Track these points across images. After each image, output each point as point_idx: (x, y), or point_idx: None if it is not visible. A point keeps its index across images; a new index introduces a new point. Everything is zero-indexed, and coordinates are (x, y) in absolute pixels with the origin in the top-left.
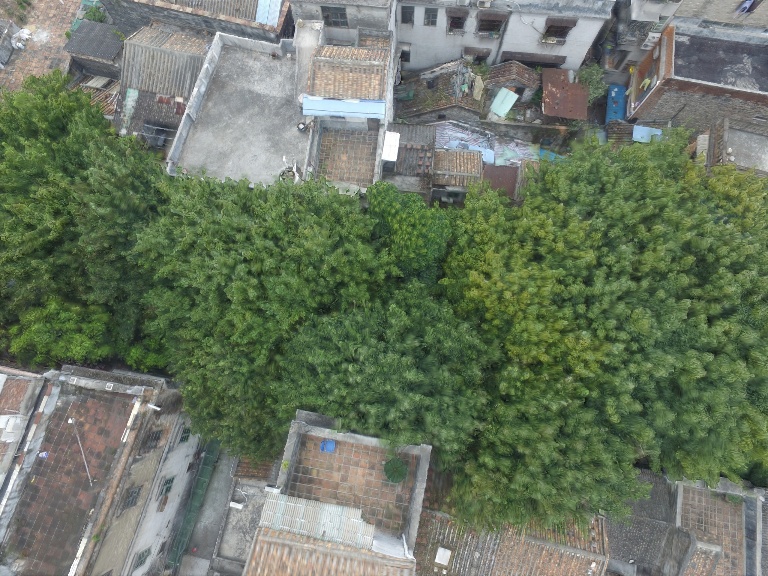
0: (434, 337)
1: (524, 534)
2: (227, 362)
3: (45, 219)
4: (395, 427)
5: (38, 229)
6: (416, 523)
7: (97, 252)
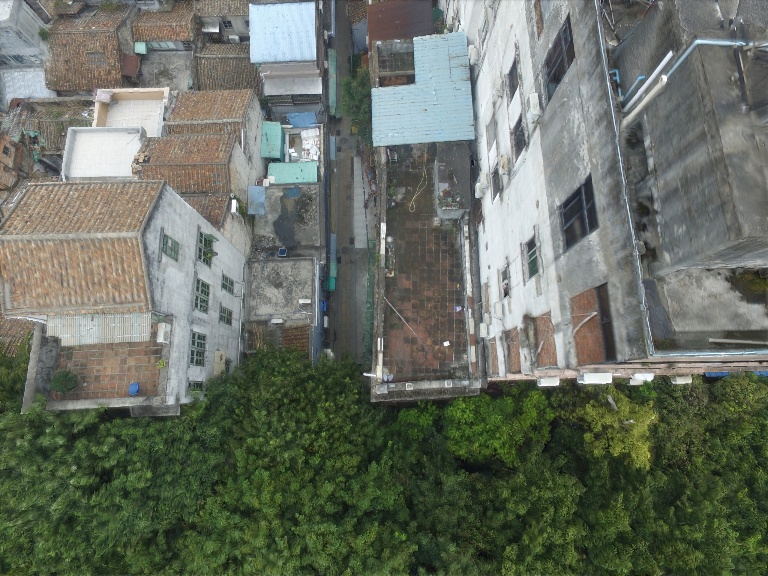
0: (14, 533)
1: (7, 343)
2: (276, 444)
3: (528, 572)
4: (49, 426)
5: (532, 556)
6: (35, 342)
7: (468, 538)
